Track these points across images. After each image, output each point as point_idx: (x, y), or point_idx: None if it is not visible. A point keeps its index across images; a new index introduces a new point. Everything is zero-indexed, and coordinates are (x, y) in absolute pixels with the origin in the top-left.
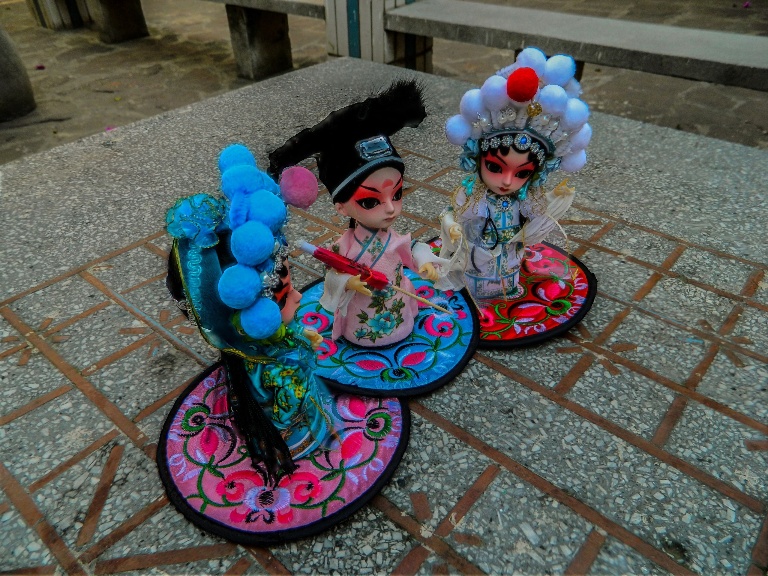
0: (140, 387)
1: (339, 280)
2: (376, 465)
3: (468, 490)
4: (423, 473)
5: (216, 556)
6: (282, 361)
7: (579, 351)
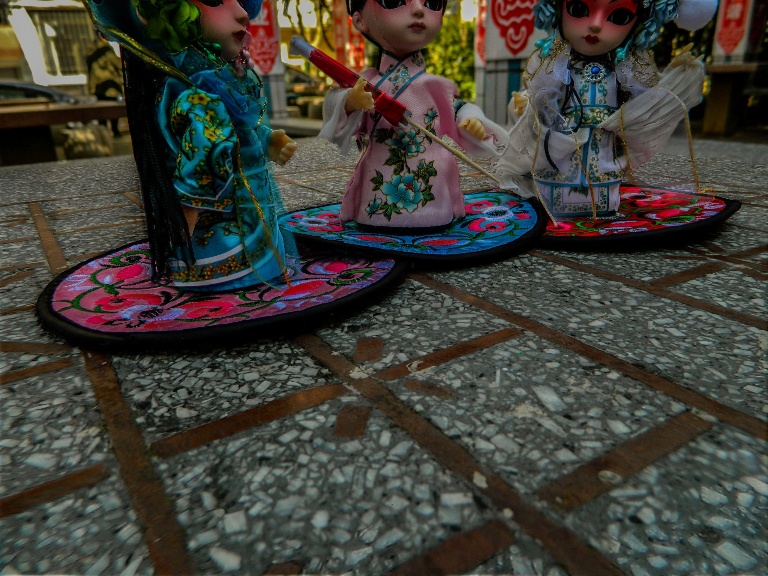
0: (101, 243)
1: (339, 95)
2: (322, 298)
3: (457, 344)
4: (393, 323)
5: (37, 351)
6: (196, 81)
7: (701, 259)
